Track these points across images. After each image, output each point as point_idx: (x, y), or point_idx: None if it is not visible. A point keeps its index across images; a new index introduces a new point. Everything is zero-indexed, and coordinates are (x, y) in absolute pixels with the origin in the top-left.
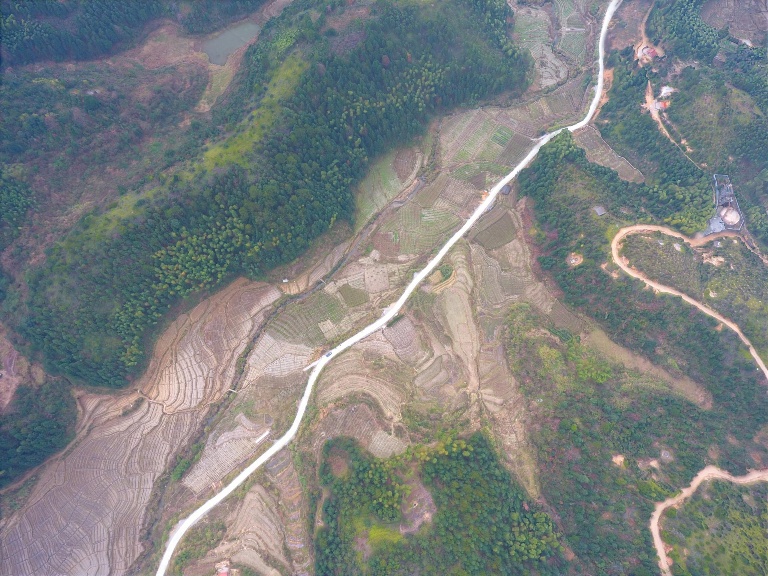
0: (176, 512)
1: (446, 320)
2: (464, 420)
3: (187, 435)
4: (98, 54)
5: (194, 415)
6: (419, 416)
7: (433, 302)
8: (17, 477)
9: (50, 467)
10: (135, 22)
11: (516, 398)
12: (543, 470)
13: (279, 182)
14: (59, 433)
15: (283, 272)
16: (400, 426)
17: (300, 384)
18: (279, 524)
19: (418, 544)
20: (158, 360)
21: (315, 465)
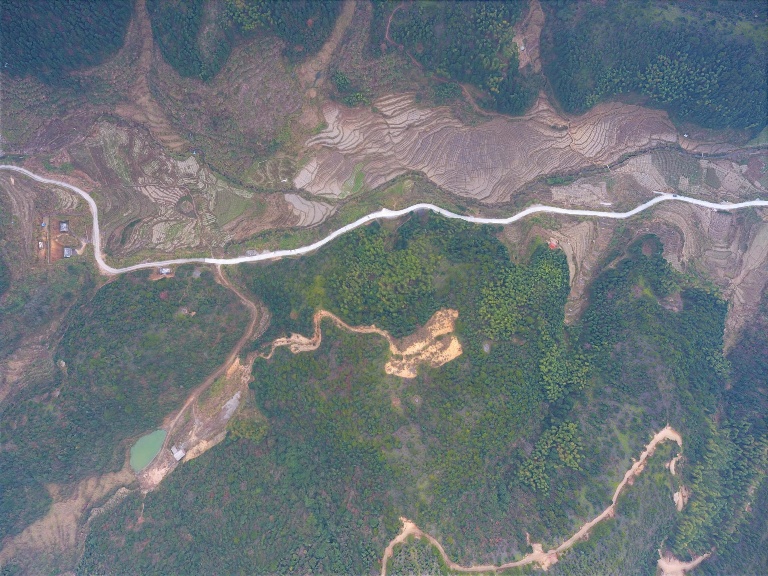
0: (539, 198)
1: (754, 237)
2: (719, 291)
3: (570, 167)
4: None
5: (582, 161)
6: (695, 268)
7: (757, 222)
8: (490, 109)
9: (500, 119)
10: None
11: (753, 308)
12: (739, 348)
13: (761, 76)
14: (525, 106)
15: (692, 130)
16: (685, 263)
17: (646, 196)
18: (588, 249)
19: (667, 314)
20: (591, 115)
21: (631, 239)
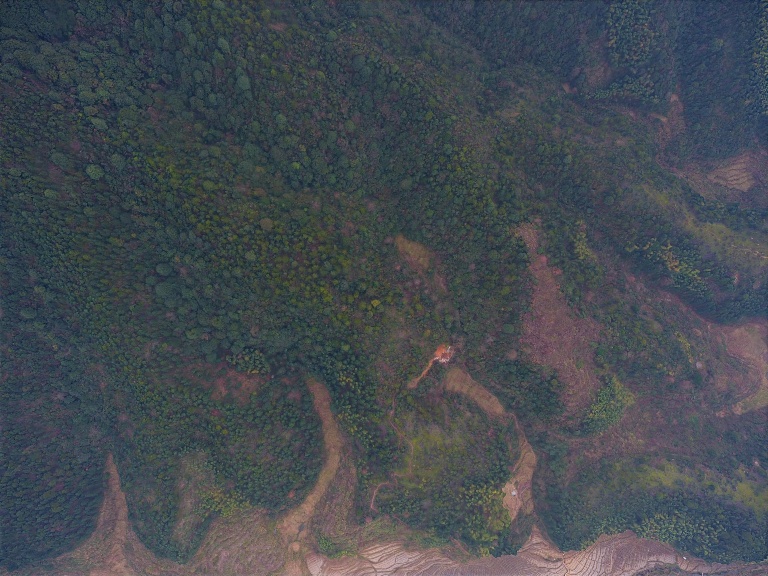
0: None
1: None
2: None
3: None
4: (710, 318)
5: None
6: None
7: None
8: None
9: None
10: (752, 316)
11: None
12: None
13: None
14: None
15: (691, 557)
16: None
17: None
18: None
19: None
20: None
21: None
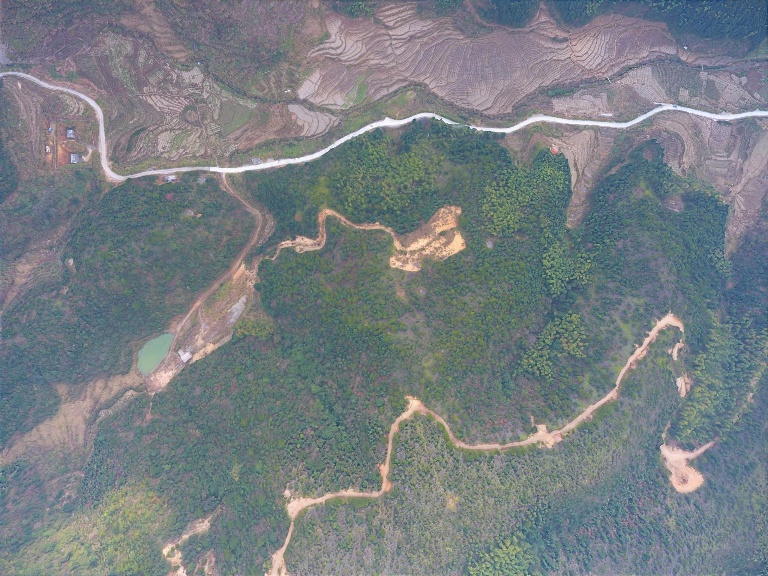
0: (540, 109)
1: (754, 145)
2: None
3: (571, 79)
4: None
5: (582, 73)
6: (696, 176)
7: (757, 130)
8: (491, 19)
9: (501, 31)
10: None
11: (754, 214)
12: (740, 252)
13: None
14: (526, 16)
15: (692, 41)
16: (686, 170)
17: (647, 107)
18: (589, 157)
19: (669, 213)
20: (591, 27)
21: (632, 146)
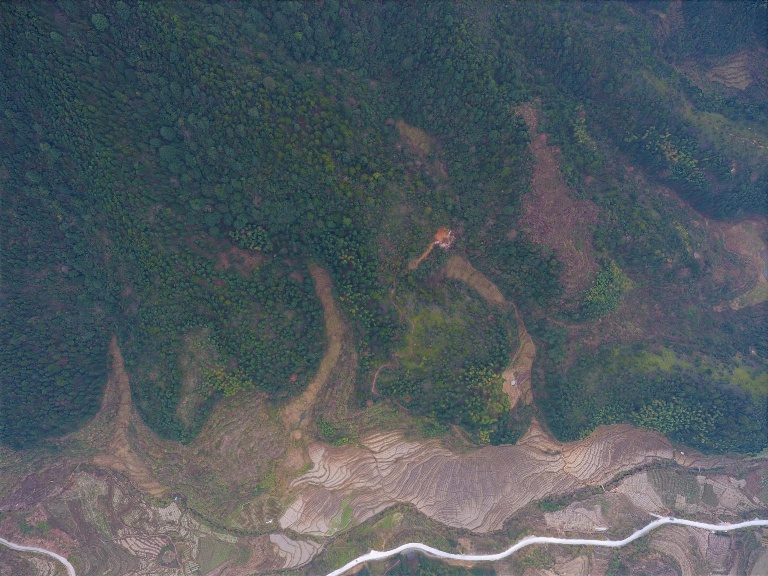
0: (532, 527)
1: (754, 565)
2: None
3: (564, 490)
4: (708, 213)
5: (575, 483)
6: None
7: (756, 548)
8: (481, 443)
9: (491, 446)
10: (749, 211)
11: None
12: None
13: None
14: None
15: (689, 450)
16: None
17: (642, 520)
18: None
19: None
20: None
21: None
